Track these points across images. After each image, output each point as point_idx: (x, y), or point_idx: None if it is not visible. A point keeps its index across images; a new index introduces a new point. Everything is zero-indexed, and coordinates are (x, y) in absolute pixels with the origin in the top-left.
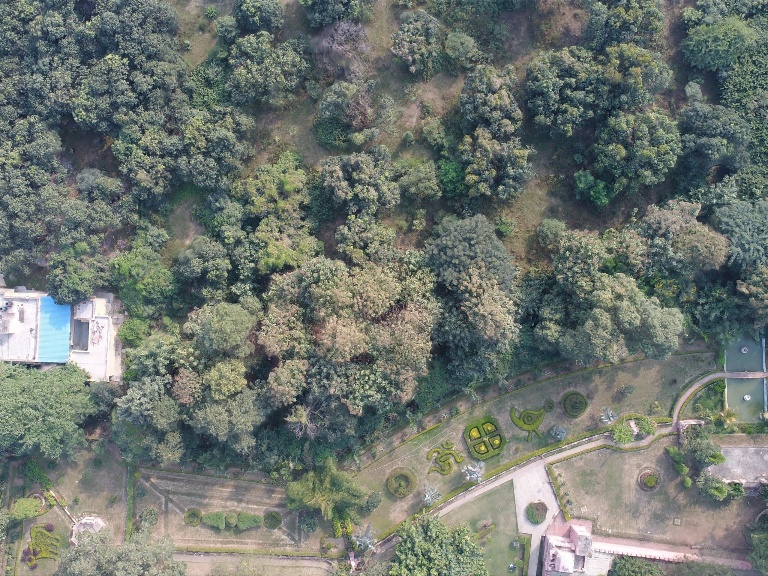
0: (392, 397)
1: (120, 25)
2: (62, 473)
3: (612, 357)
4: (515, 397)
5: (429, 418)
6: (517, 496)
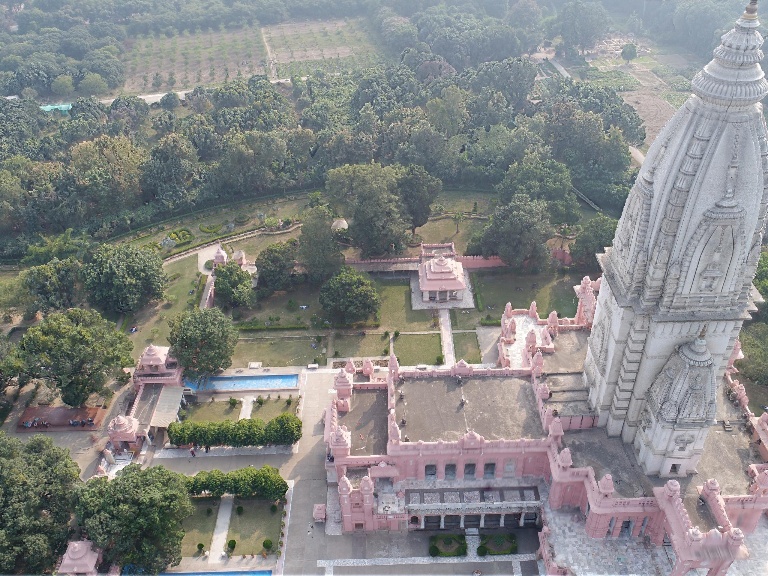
0: (110, 183)
1: (6, 117)
2: None
3: (241, 148)
4: (204, 221)
5: (144, 233)
6: (200, 260)
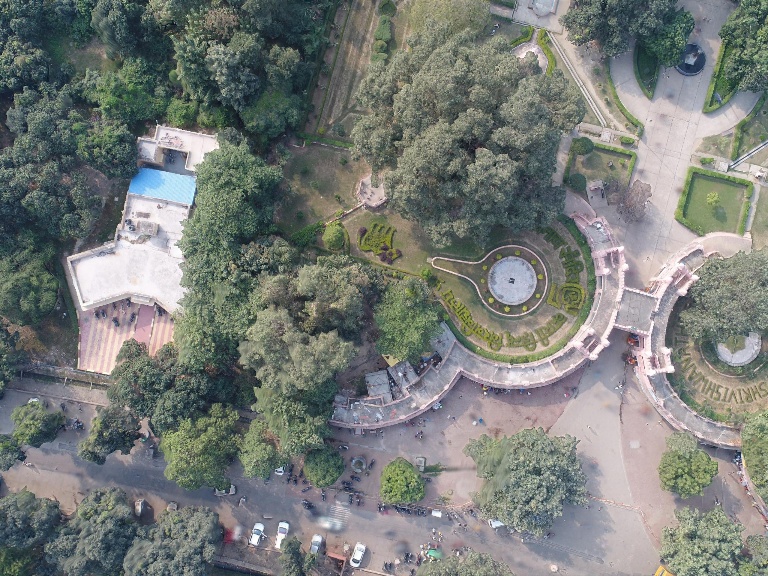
0: None
1: None
2: (311, 211)
3: None
4: None
5: None
6: None
